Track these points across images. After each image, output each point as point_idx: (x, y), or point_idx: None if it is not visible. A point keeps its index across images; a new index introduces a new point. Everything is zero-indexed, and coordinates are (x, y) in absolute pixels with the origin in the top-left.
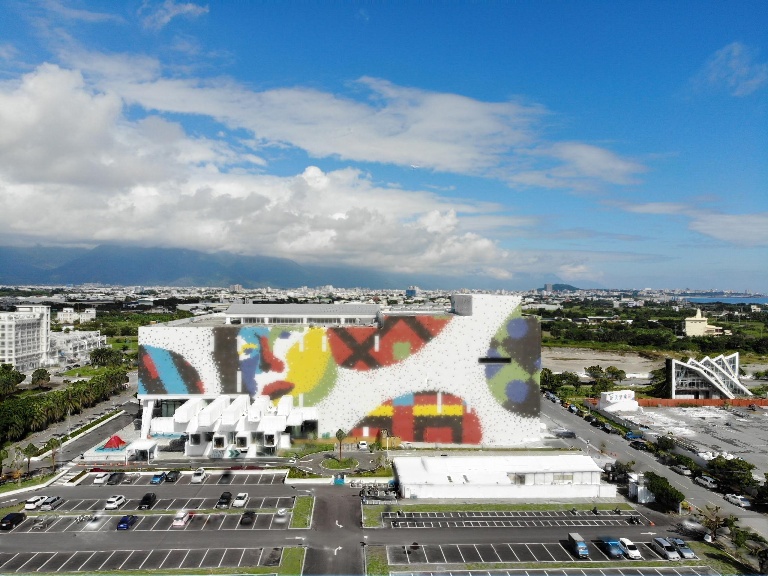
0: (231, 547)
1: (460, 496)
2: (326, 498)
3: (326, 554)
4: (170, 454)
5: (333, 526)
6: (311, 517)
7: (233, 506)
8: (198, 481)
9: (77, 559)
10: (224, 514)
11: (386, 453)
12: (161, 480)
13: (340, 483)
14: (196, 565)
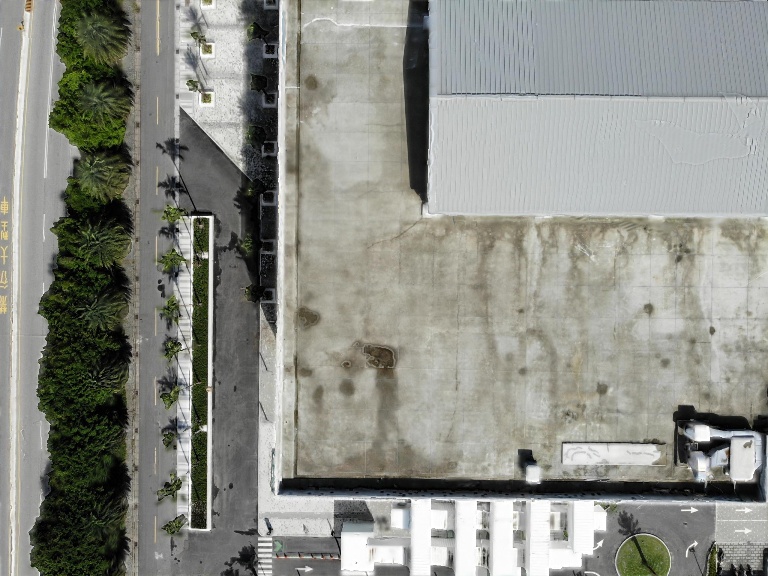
0: None
1: None
2: None
3: None
4: (389, 510)
5: None
6: None
7: None
8: None
9: None
10: None
11: (714, 512)
12: None
13: None
14: None
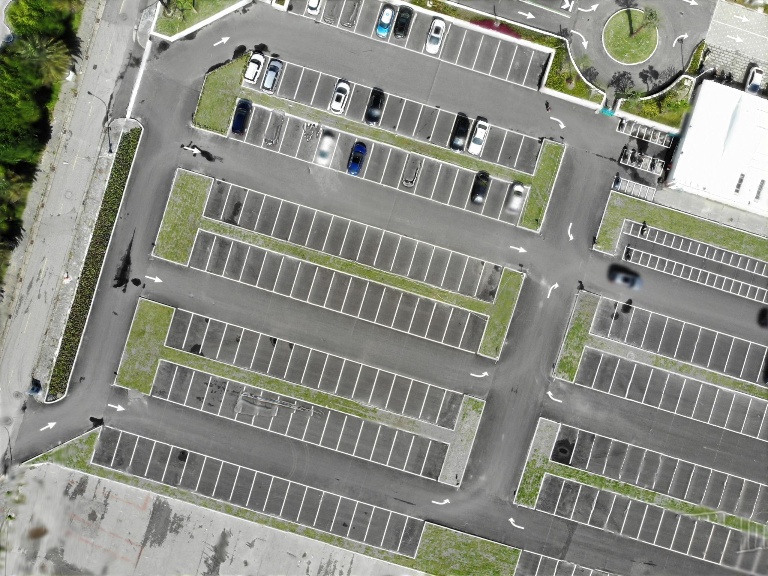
0: (456, 250)
1: (734, 205)
2: (577, 156)
3: (540, 294)
4: None
5: (563, 236)
6: (547, 207)
7: (468, 152)
8: (434, 52)
9: (319, 228)
10: (457, 167)
11: (713, 9)
12: (389, 30)
13: (608, 114)
14: (422, 277)
